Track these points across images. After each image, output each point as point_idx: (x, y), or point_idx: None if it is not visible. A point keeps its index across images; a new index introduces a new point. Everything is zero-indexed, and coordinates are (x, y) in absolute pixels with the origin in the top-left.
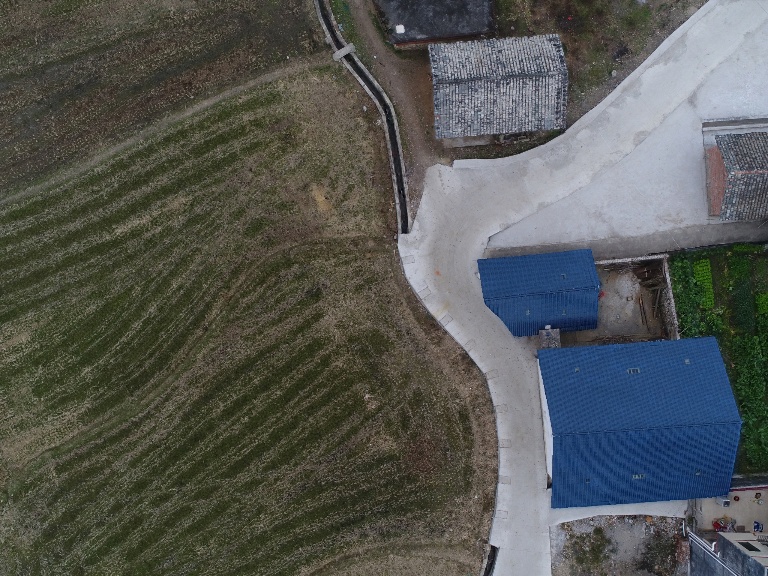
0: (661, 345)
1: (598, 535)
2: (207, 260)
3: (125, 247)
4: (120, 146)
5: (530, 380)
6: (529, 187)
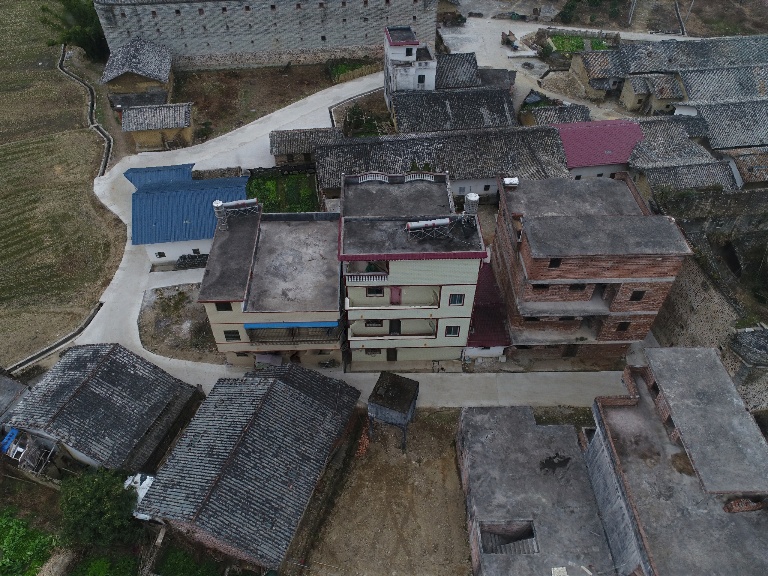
0: None
1: (180, 295)
2: None
3: None
4: None
5: None
6: (177, 160)
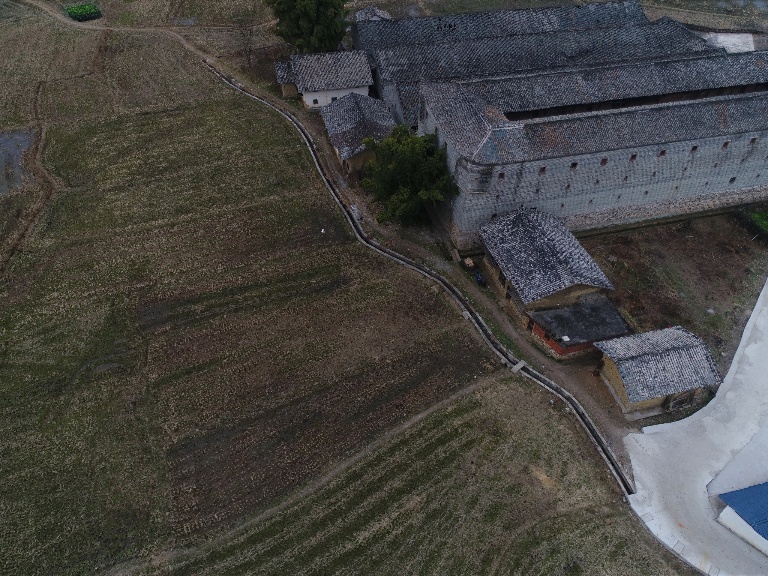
0: None
1: None
2: (454, 553)
3: (369, 553)
4: (351, 460)
5: None
6: (714, 439)
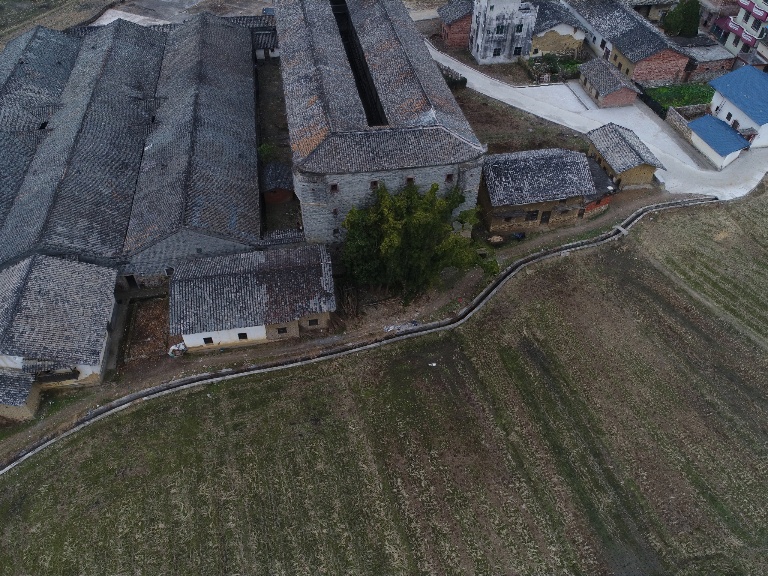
0: (725, 94)
1: None
2: None
3: None
4: (761, 343)
5: (762, 151)
6: None
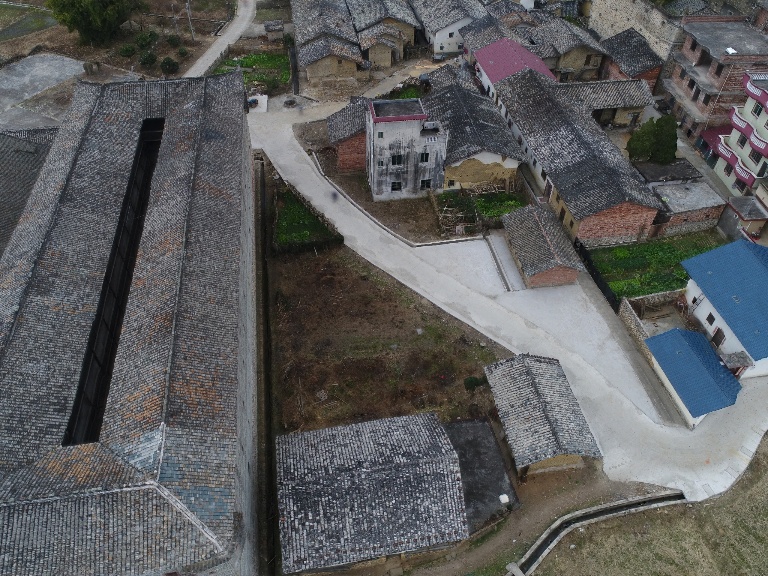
0: (704, 288)
1: None
2: None
3: None
4: None
5: (759, 384)
6: (598, 395)
